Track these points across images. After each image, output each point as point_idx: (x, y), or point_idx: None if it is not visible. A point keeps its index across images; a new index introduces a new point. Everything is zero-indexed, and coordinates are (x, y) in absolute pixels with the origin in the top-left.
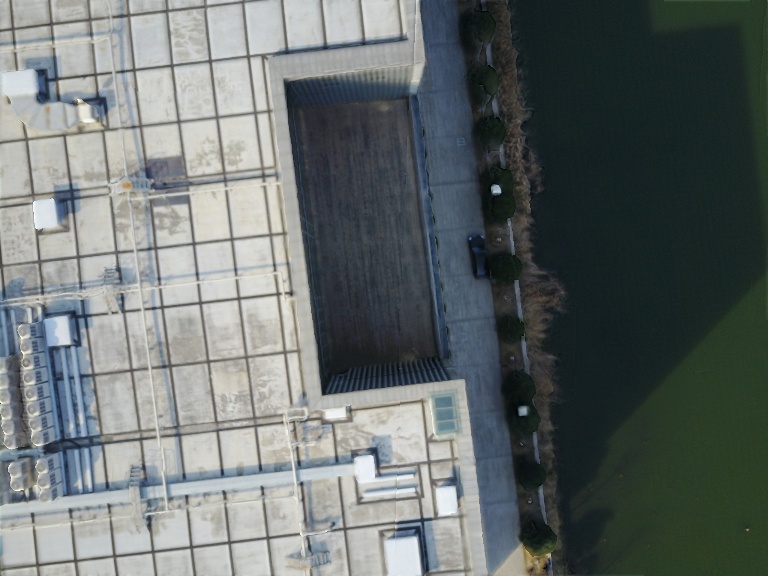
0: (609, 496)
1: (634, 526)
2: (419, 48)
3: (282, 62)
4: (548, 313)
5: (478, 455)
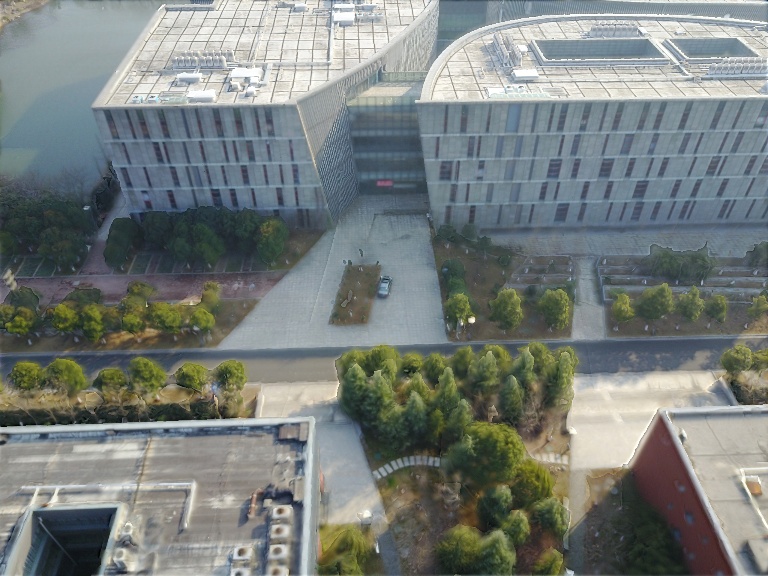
0: None
1: None
2: None
3: None
4: None
5: None
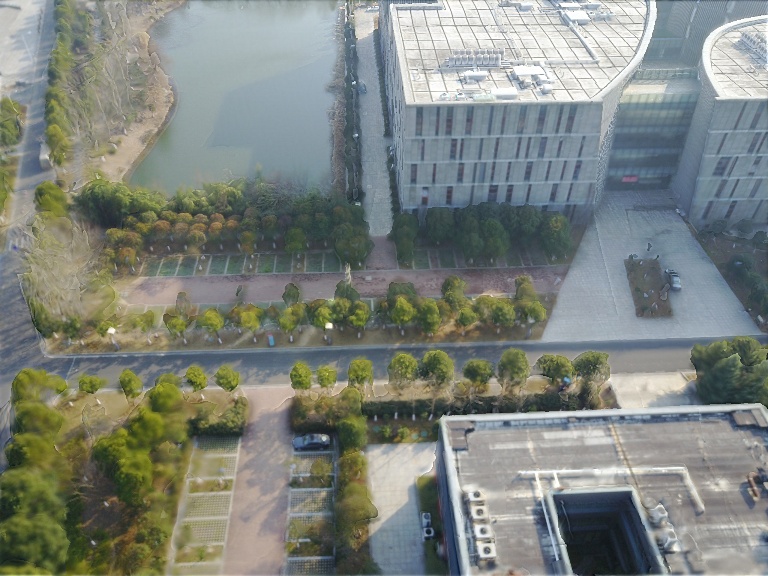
0: (318, 53)
1: (310, 48)
2: (392, 5)
3: (439, 5)
4: (334, 82)
5: (370, 55)
